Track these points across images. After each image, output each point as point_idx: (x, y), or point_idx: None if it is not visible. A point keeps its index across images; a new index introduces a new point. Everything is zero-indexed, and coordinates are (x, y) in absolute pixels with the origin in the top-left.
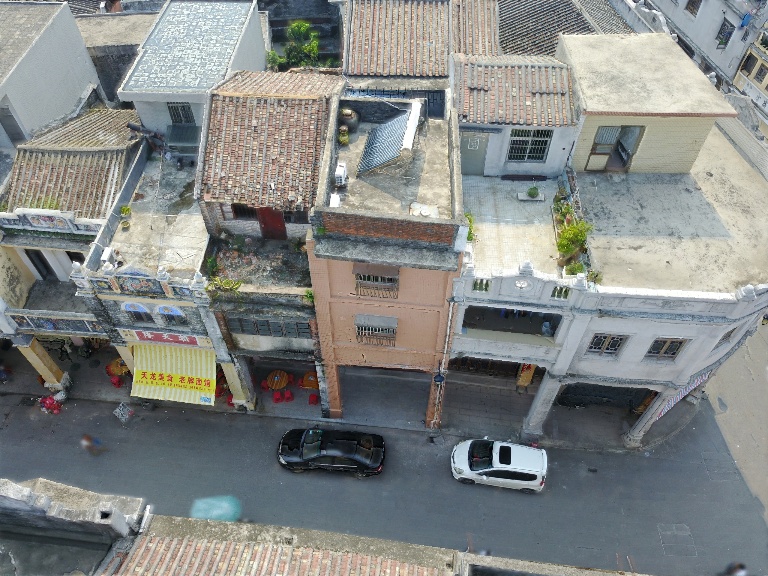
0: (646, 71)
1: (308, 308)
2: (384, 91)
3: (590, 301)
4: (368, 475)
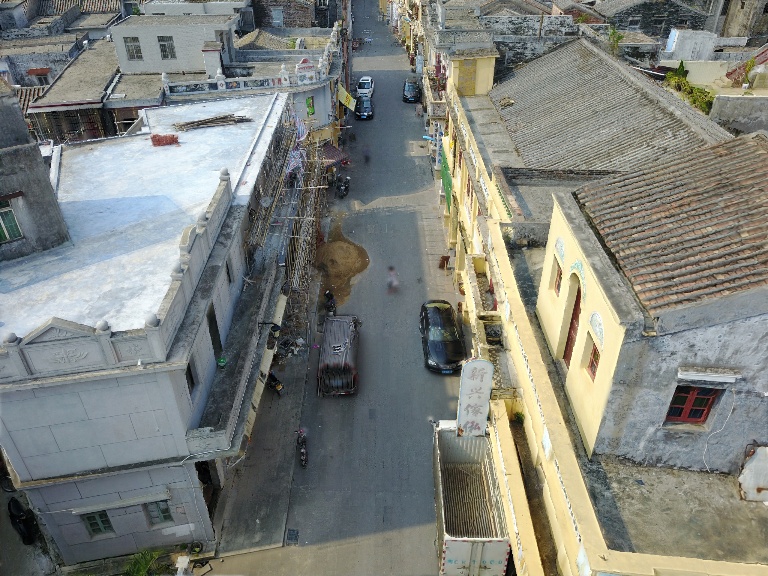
0: None
1: None
2: None
3: None
4: None
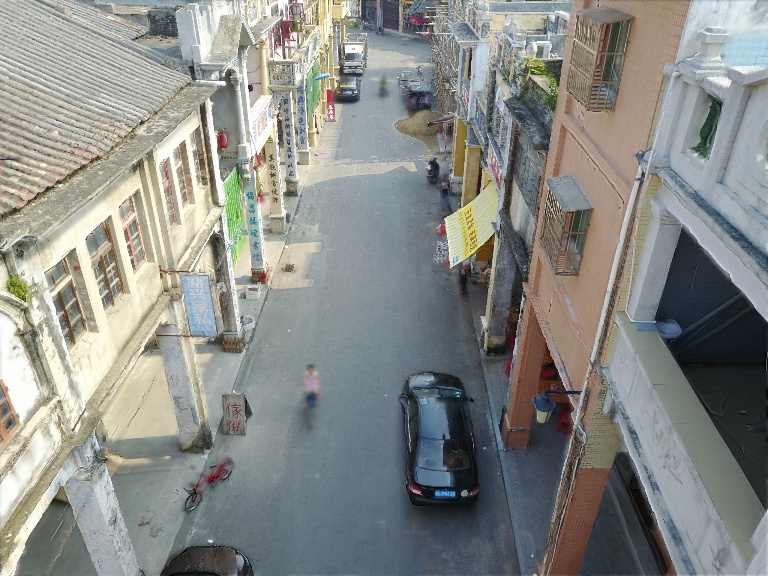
0: None
1: None
2: None
3: None
4: None
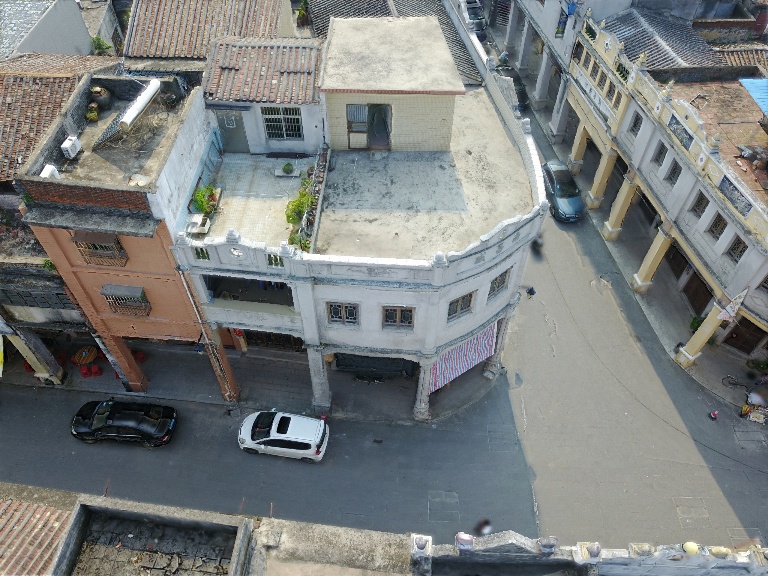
0: (397, 52)
1: (58, 278)
2: (158, 72)
3: (300, 268)
4: (156, 445)
